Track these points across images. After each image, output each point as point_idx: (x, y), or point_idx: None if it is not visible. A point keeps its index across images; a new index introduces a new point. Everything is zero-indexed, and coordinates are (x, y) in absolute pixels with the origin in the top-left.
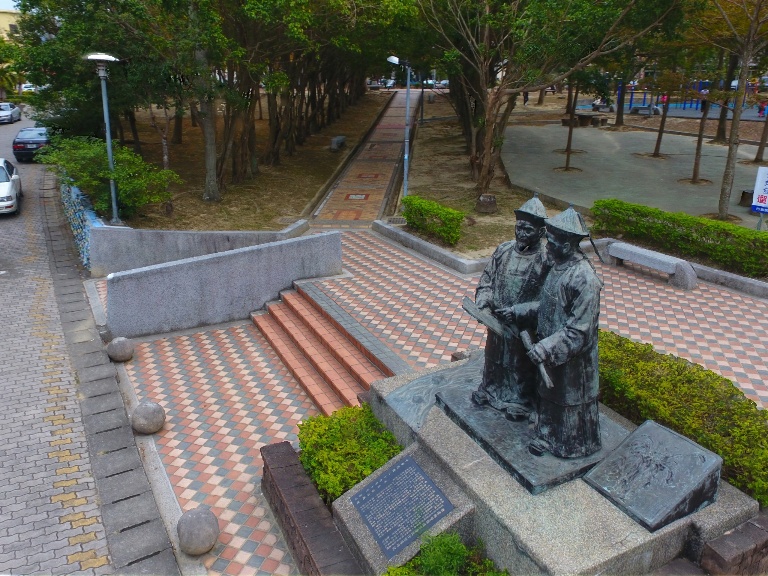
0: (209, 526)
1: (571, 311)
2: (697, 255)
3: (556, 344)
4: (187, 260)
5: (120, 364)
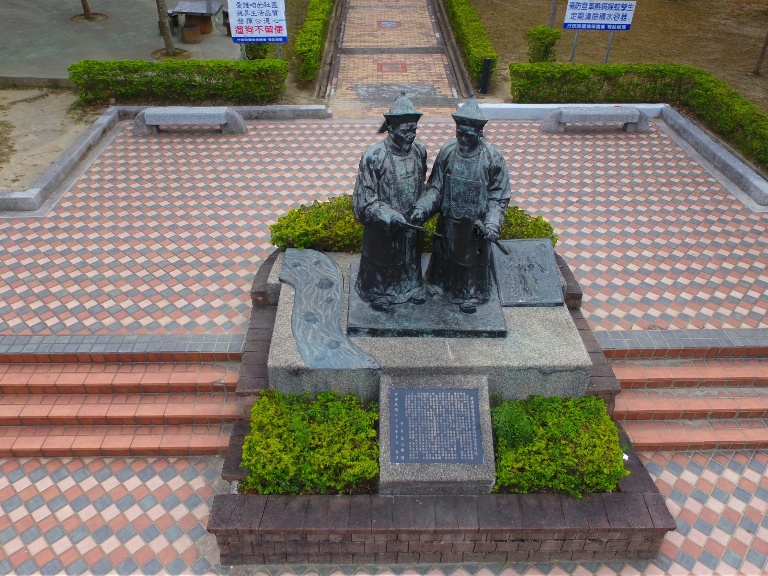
0: None
1: (497, 187)
2: (208, 98)
3: (500, 218)
4: None
5: None
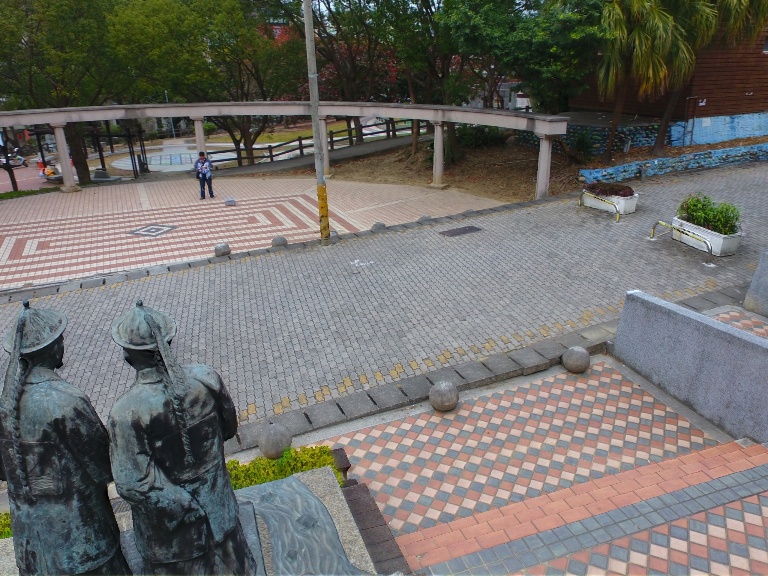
0: (266, 439)
1: None
2: None
3: None
4: (703, 318)
5: (564, 369)
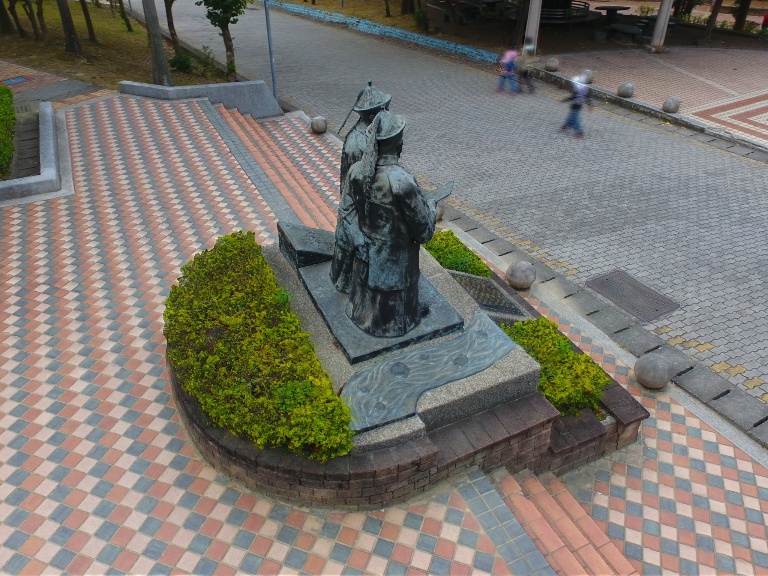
0: None
1: None
2: None
3: None
4: None
5: None
